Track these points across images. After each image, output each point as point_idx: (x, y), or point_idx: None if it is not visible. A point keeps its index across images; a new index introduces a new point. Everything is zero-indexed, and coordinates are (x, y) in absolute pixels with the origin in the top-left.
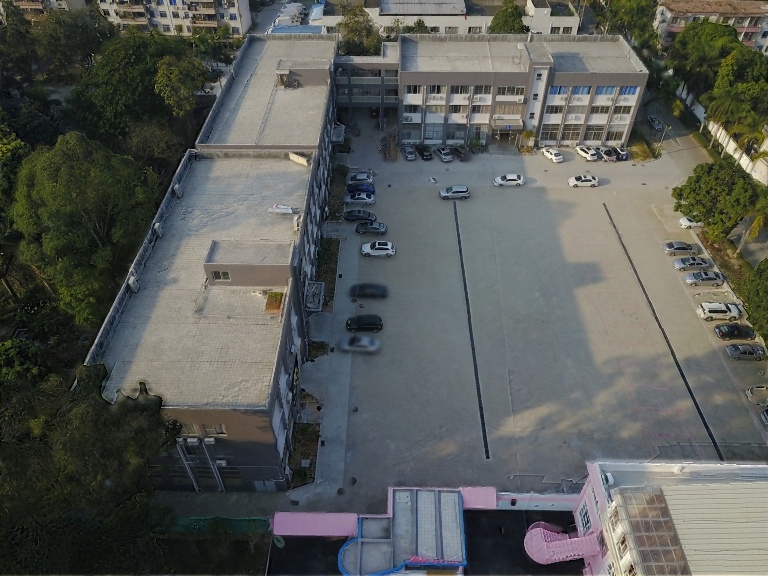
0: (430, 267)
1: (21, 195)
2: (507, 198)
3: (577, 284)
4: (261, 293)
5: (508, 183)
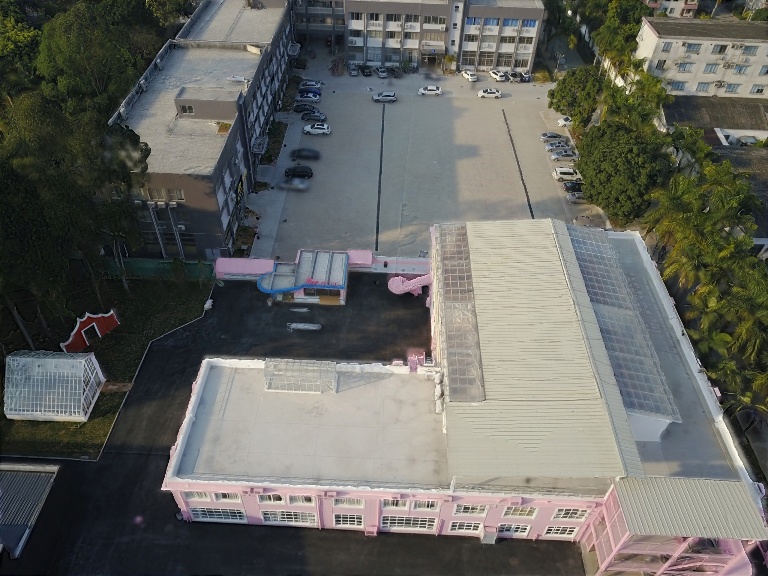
0: (356, 143)
1: (44, 46)
2: (426, 103)
3: (467, 157)
4: (216, 123)
5: (429, 93)
